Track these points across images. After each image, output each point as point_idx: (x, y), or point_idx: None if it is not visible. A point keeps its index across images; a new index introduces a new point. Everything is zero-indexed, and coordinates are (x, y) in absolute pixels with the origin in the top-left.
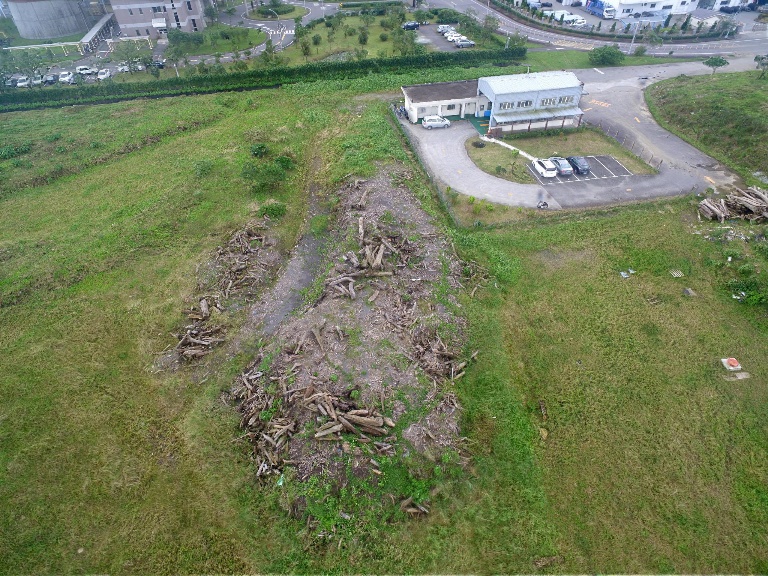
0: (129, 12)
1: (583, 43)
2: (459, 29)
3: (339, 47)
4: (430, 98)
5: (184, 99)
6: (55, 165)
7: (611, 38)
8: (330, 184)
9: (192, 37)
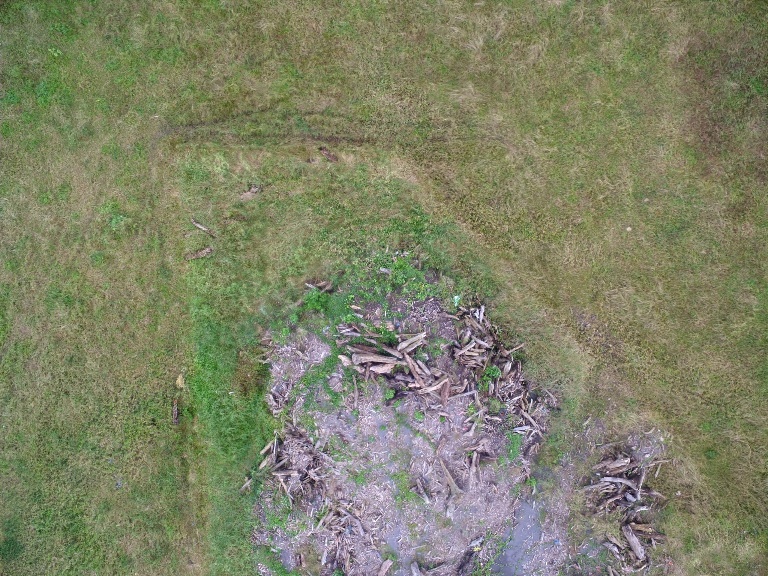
0: None
1: None
2: None
3: None
4: None
5: None
6: None
7: None
8: None
9: None
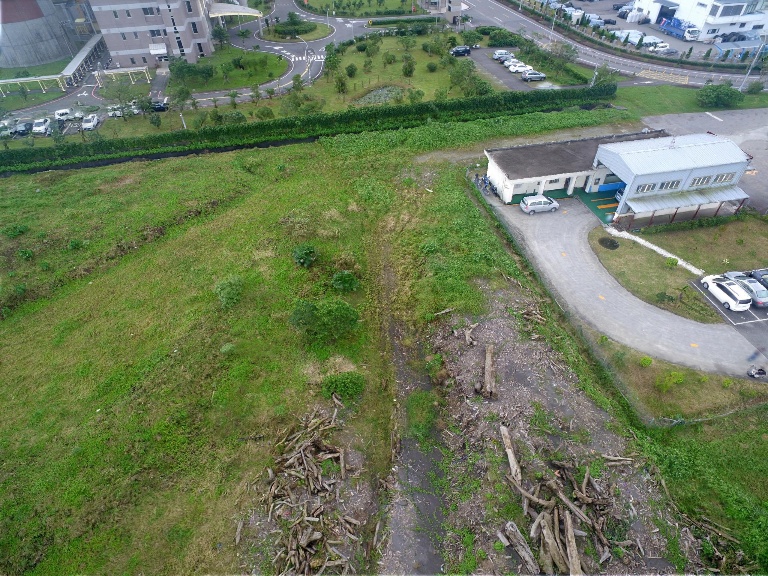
0: (122, 36)
1: (674, 74)
2: (518, 55)
3: (380, 80)
4: (530, 170)
5: (194, 162)
6: (15, 285)
7: (705, 67)
8: (419, 323)
9: (200, 70)
